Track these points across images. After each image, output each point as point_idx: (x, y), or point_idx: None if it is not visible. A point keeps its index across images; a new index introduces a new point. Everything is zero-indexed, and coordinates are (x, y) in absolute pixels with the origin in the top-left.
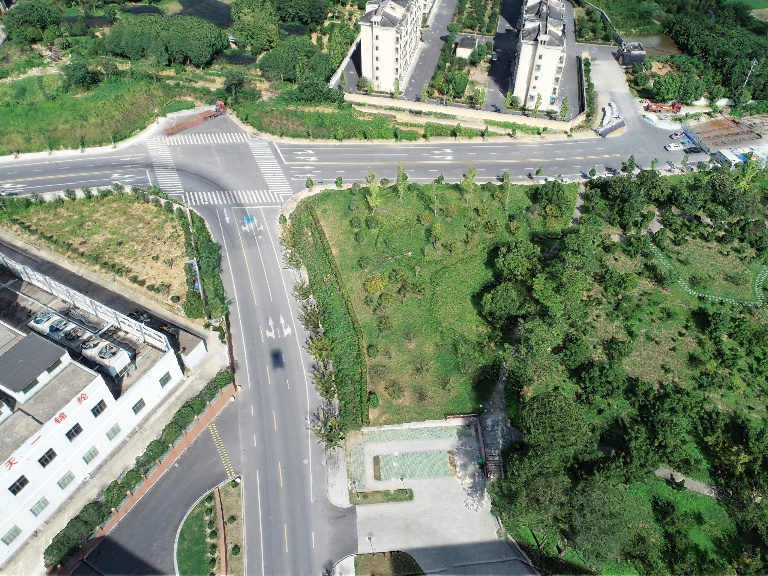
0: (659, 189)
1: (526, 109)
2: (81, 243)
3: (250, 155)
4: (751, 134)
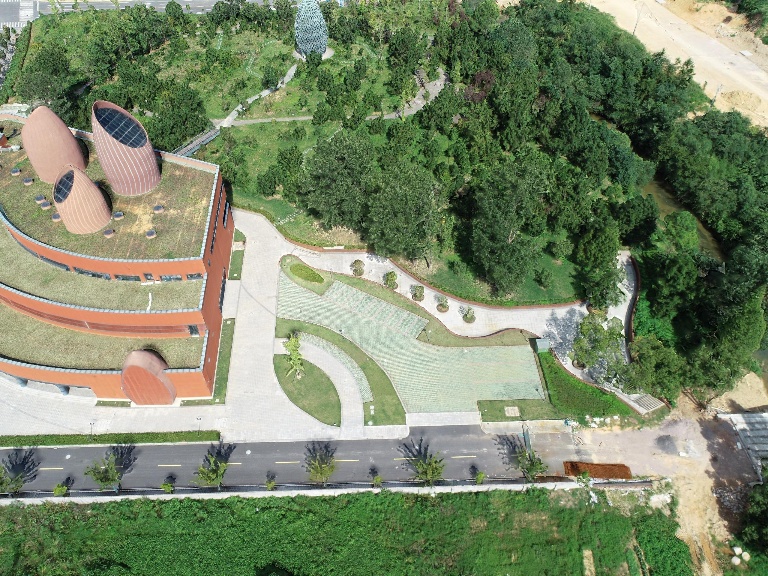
0: (243, 8)
1: None
2: None
3: (17, 7)
4: None
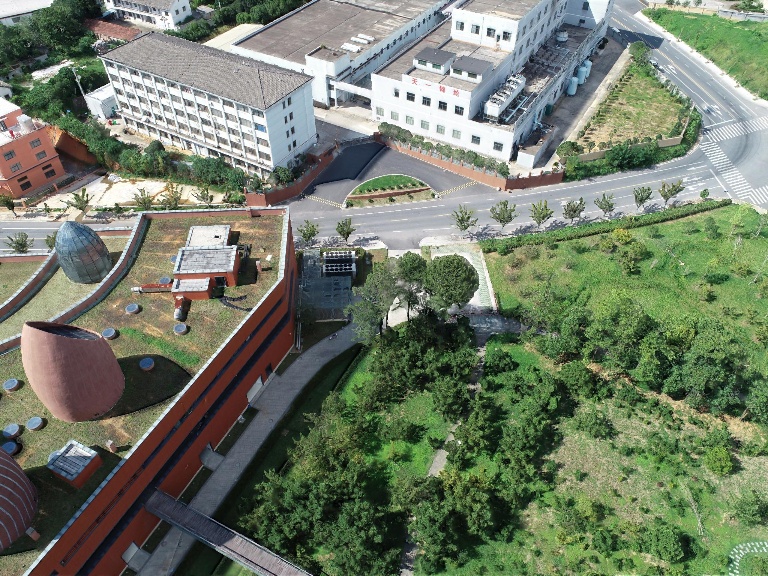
0: None
1: None
2: (621, 103)
3: None
4: None
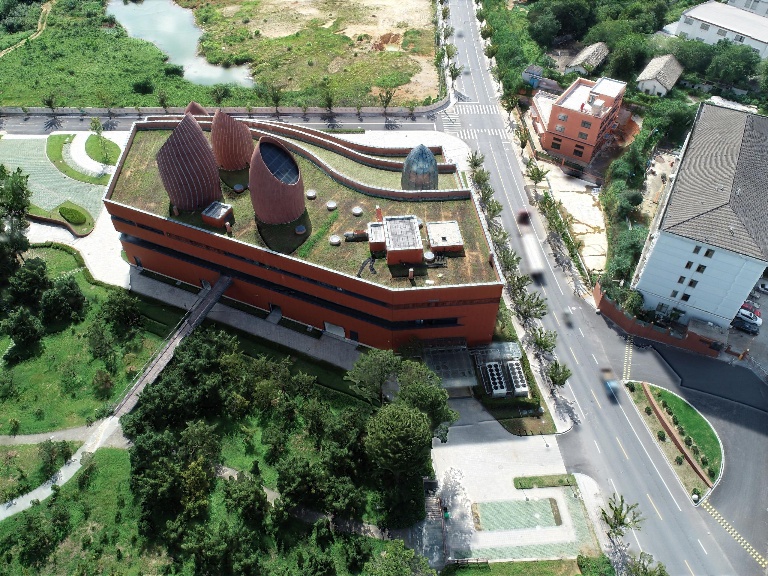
0: None
1: None
2: None
3: None
4: None
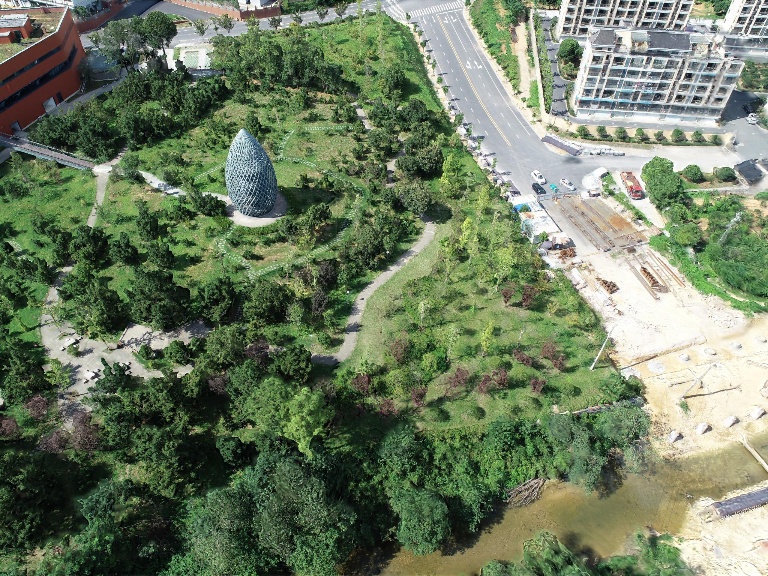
0: None
1: (567, 98)
2: None
3: (442, 4)
4: (605, 243)
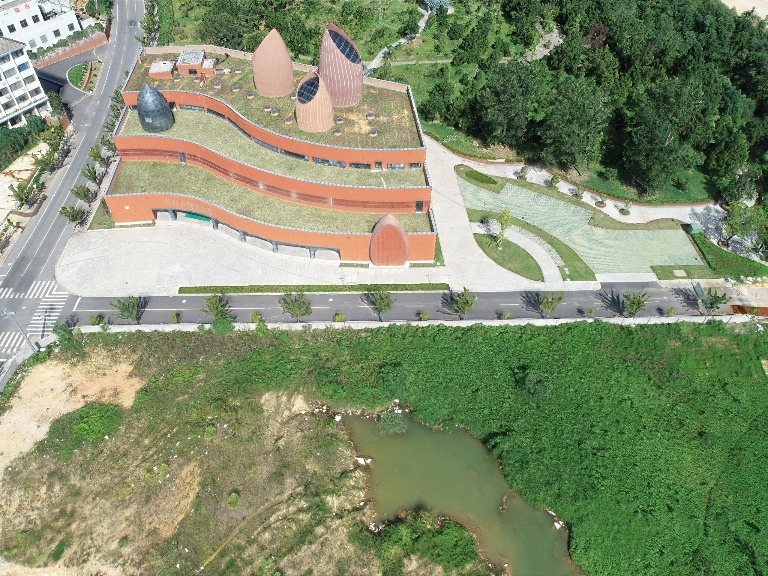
0: None
1: None
2: None
3: None
4: None
